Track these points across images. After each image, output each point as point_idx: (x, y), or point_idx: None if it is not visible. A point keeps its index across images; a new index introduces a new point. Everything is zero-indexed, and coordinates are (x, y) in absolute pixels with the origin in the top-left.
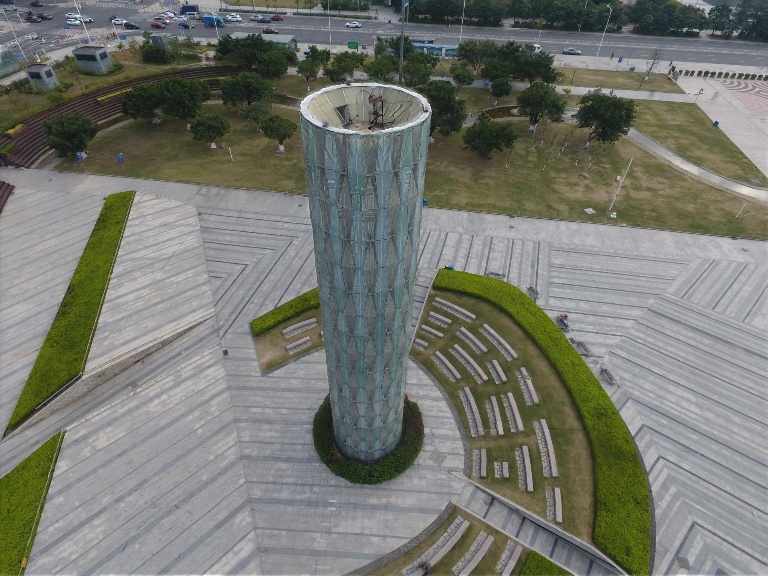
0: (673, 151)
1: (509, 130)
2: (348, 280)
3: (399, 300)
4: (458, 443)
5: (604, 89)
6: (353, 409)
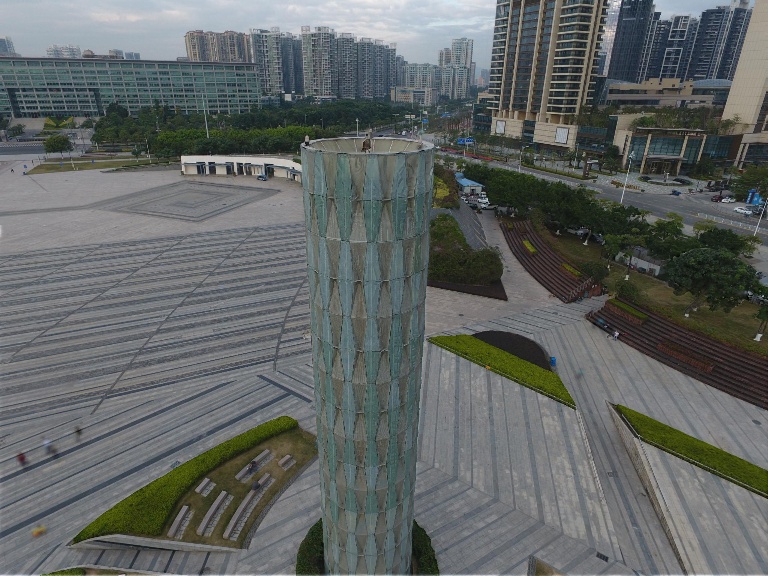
0: None
1: None
2: None
3: None
4: None
5: None
6: None
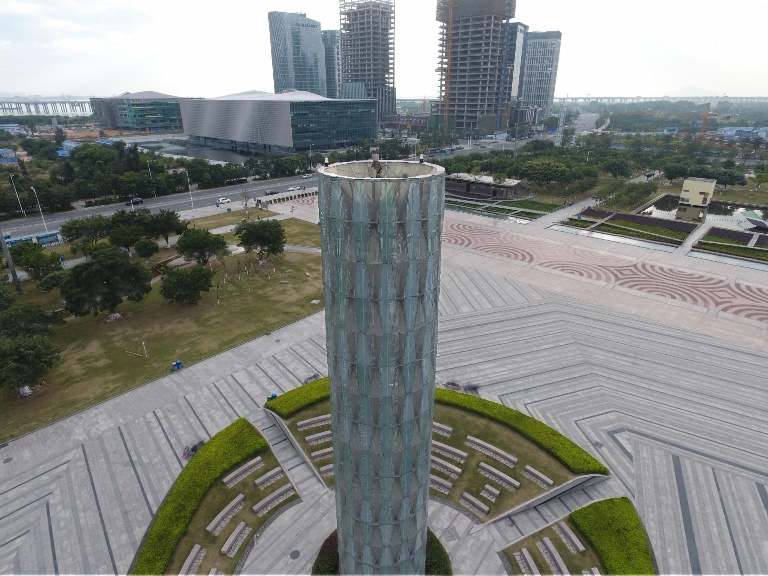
0: (316, 247)
1: (207, 269)
2: (416, 346)
3: None
4: (446, 509)
5: (225, 227)
6: (410, 530)
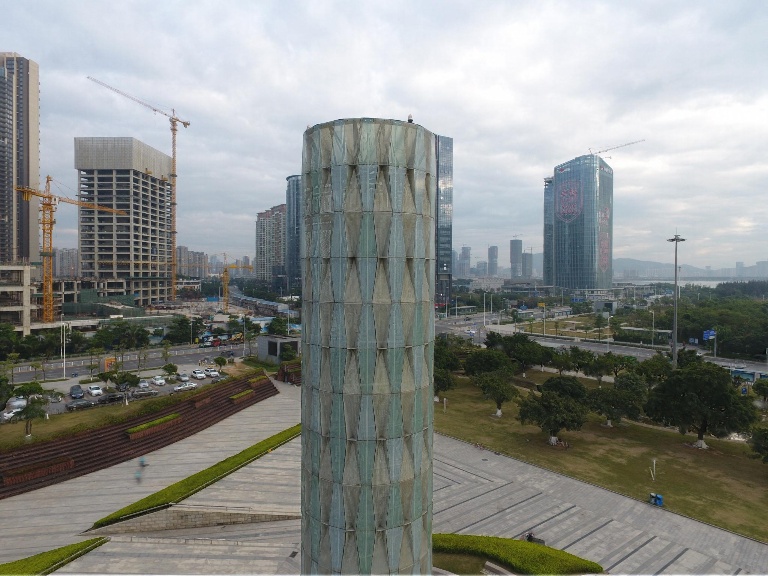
0: None
1: None
2: None
3: (369, 379)
4: None
5: None
6: None
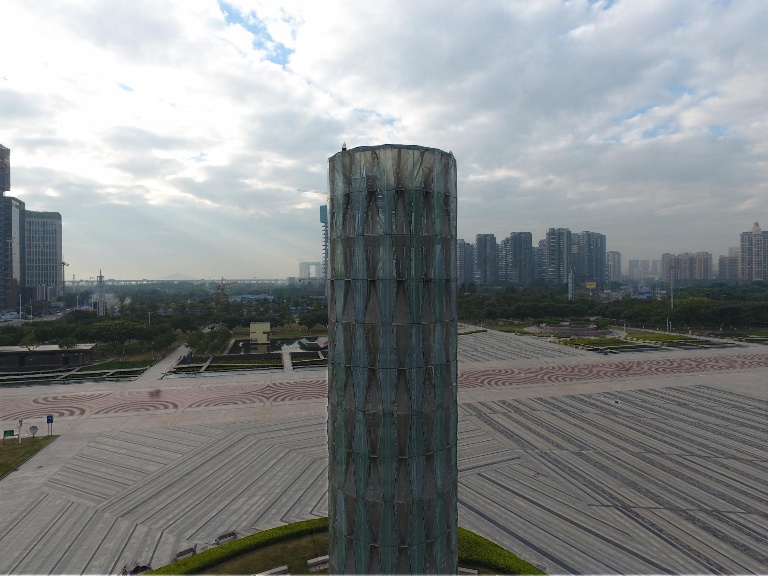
0: None
1: None
2: None
3: None
4: None
5: None
6: None
